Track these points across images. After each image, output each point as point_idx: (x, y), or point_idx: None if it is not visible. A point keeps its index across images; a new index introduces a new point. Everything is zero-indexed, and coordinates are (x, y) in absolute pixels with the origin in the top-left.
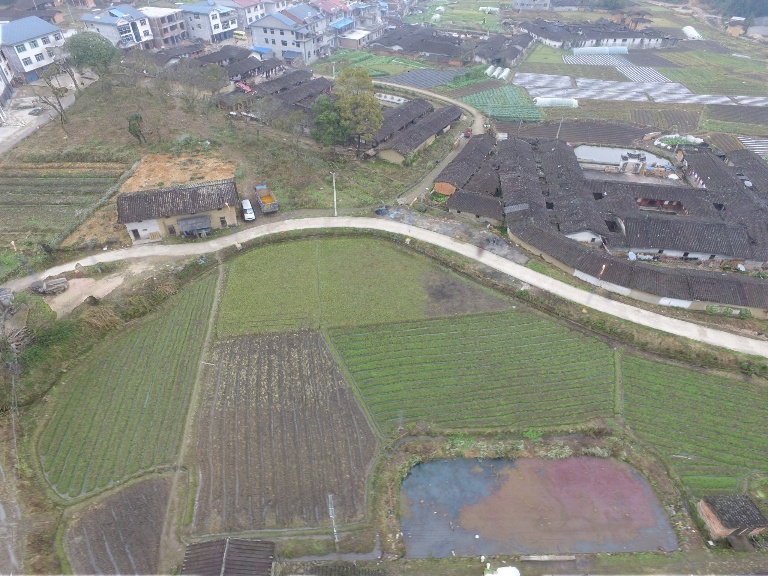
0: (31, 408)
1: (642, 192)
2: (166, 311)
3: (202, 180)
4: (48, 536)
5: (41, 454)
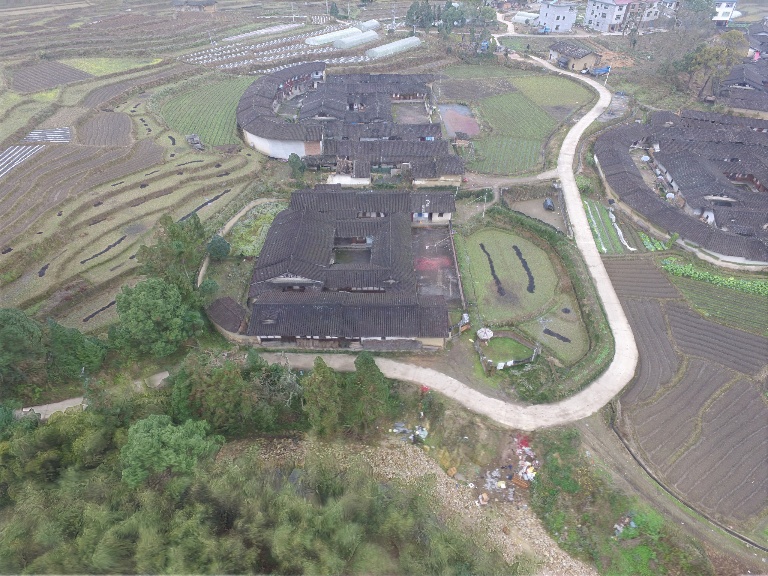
0: (466, 64)
1: (764, 175)
2: (514, 71)
3: (607, 61)
4: (433, 71)
5: (453, 68)
